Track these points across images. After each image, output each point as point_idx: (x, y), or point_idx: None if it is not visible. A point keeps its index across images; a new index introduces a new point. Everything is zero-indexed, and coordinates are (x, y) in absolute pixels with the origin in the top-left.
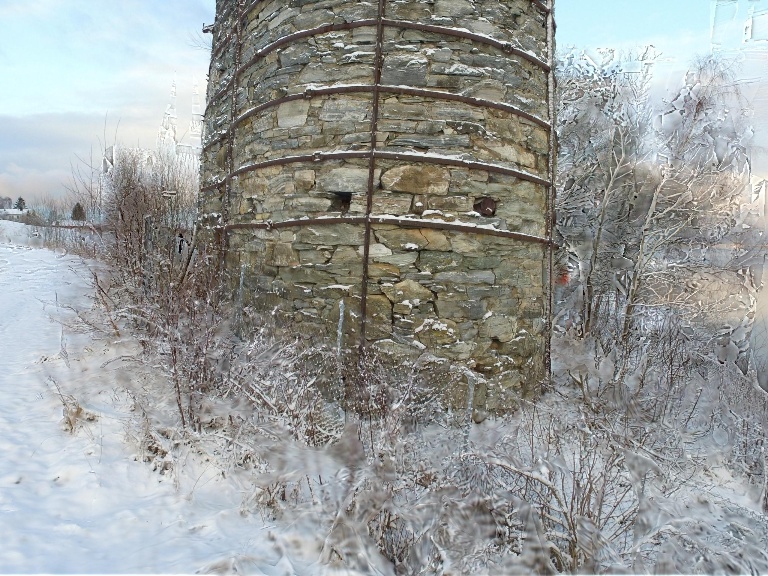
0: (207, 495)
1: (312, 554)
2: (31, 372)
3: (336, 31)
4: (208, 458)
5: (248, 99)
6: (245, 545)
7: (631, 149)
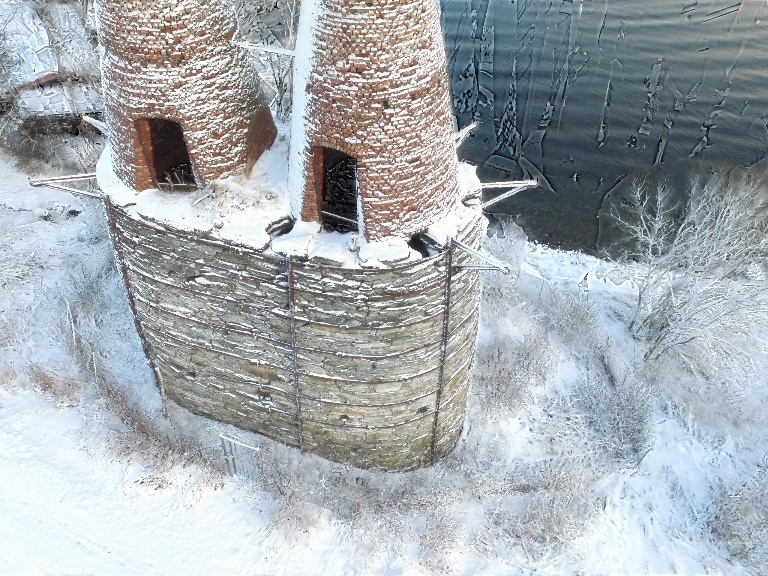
0: (467, 565)
1: (524, 560)
2: (282, 573)
3: (419, 350)
4: (450, 552)
5: (324, 368)
6: (507, 573)
7: None
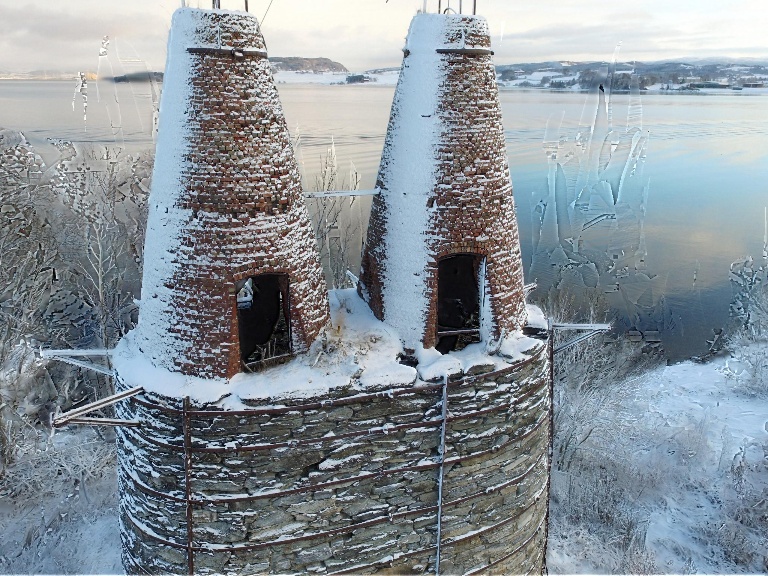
0: None
1: None
2: None
3: None
4: None
5: (470, 522)
6: None
7: (107, 243)
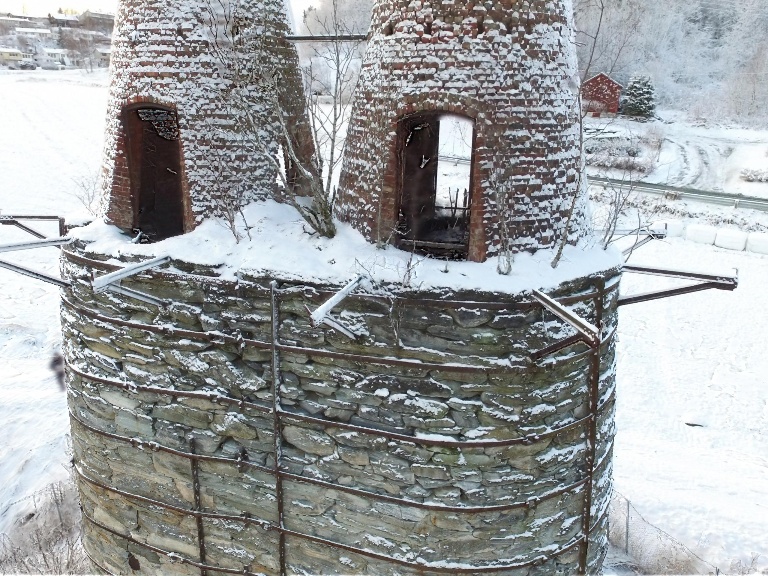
0: None
1: None
2: None
3: None
4: None
5: None
6: None
7: None
